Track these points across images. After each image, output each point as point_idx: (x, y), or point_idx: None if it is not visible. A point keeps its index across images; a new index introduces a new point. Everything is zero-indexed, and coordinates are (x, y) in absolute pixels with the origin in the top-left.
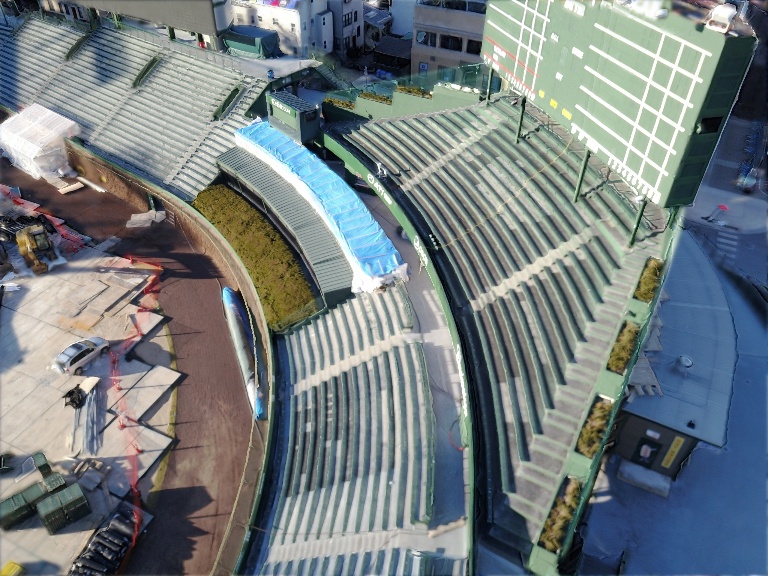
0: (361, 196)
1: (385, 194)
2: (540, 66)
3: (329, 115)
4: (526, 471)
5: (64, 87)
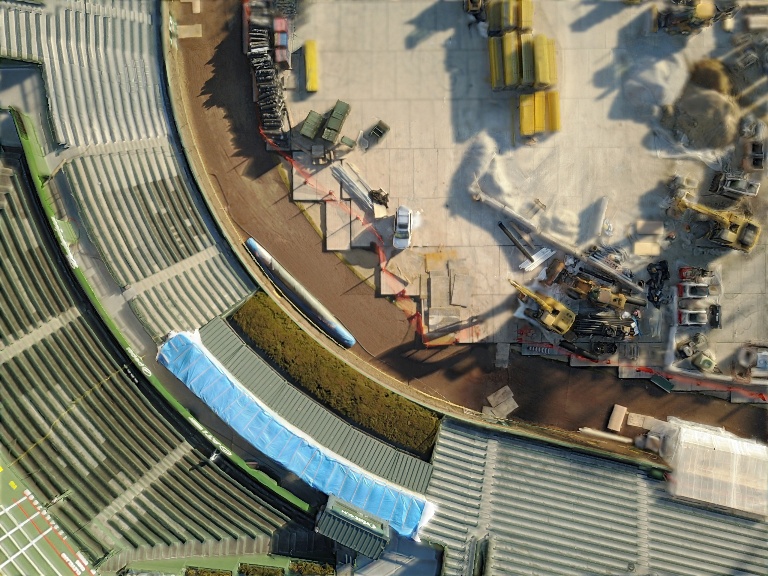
0: (251, 457)
1: (200, 429)
2: (7, 505)
3: (326, 556)
4: (6, 189)
5: (762, 560)
